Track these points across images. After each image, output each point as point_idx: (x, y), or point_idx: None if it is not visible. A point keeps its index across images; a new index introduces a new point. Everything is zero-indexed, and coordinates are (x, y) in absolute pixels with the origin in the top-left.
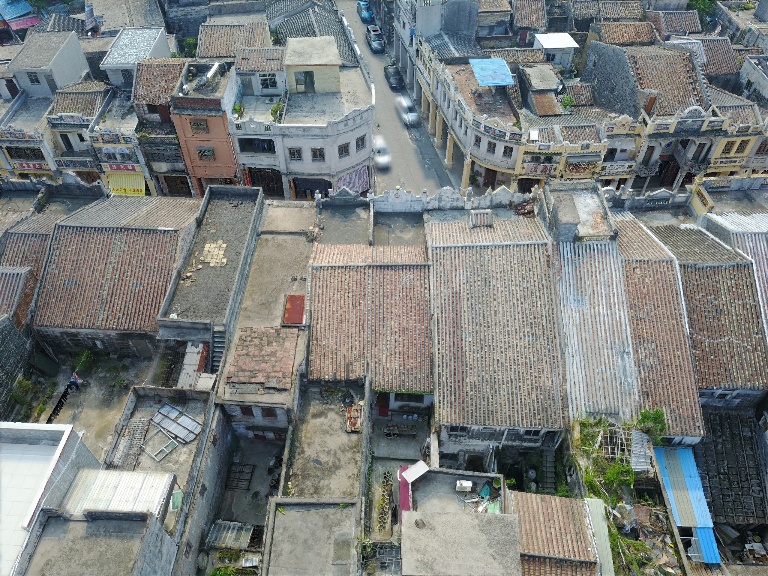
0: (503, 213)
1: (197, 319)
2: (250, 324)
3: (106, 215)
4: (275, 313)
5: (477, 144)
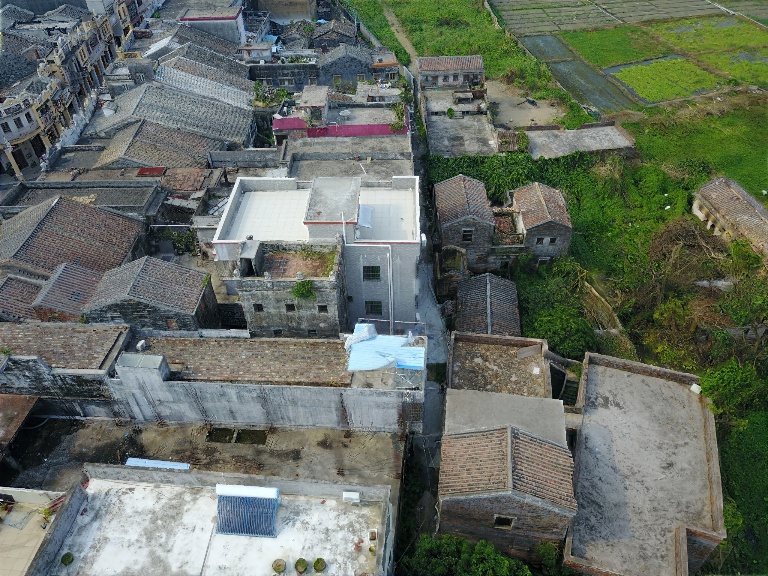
0: (100, 112)
1: None
2: None
3: (1, 252)
4: None
5: (6, 131)
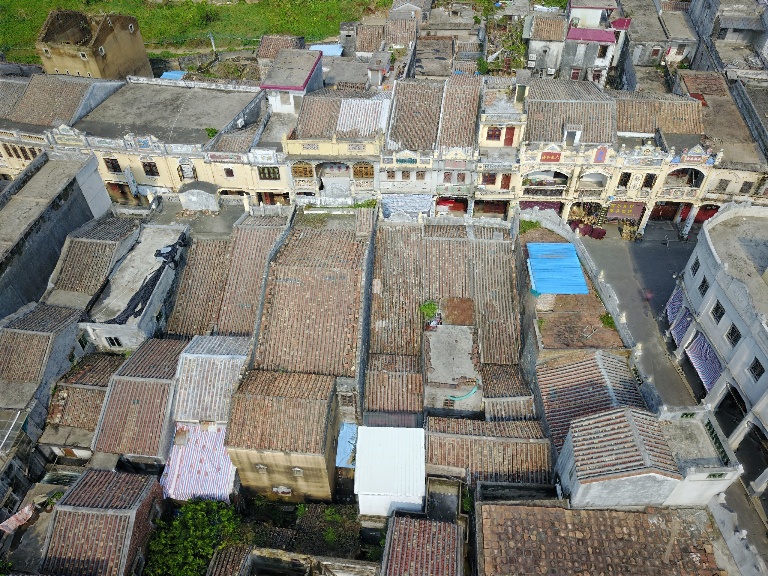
0: None
1: (760, 90)
2: (724, 98)
3: None
4: (710, 101)
5: None
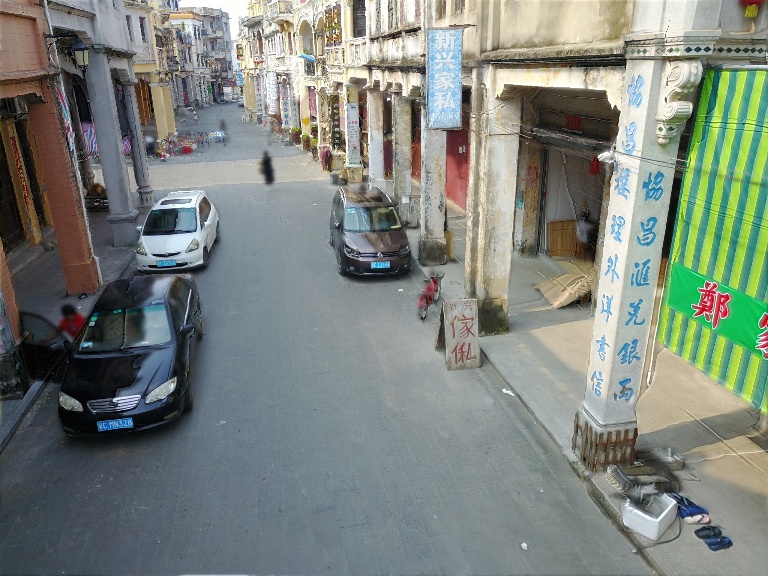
0: None
1: None
2: None
3: None
4: None
5: None
